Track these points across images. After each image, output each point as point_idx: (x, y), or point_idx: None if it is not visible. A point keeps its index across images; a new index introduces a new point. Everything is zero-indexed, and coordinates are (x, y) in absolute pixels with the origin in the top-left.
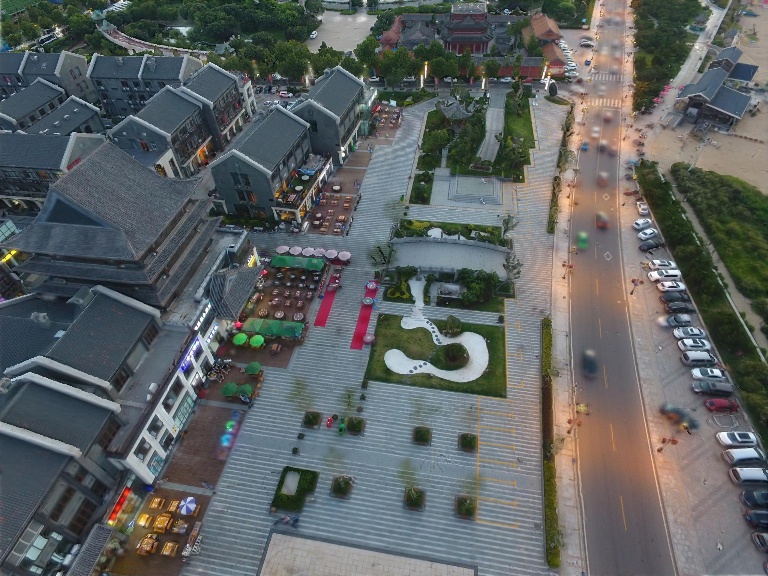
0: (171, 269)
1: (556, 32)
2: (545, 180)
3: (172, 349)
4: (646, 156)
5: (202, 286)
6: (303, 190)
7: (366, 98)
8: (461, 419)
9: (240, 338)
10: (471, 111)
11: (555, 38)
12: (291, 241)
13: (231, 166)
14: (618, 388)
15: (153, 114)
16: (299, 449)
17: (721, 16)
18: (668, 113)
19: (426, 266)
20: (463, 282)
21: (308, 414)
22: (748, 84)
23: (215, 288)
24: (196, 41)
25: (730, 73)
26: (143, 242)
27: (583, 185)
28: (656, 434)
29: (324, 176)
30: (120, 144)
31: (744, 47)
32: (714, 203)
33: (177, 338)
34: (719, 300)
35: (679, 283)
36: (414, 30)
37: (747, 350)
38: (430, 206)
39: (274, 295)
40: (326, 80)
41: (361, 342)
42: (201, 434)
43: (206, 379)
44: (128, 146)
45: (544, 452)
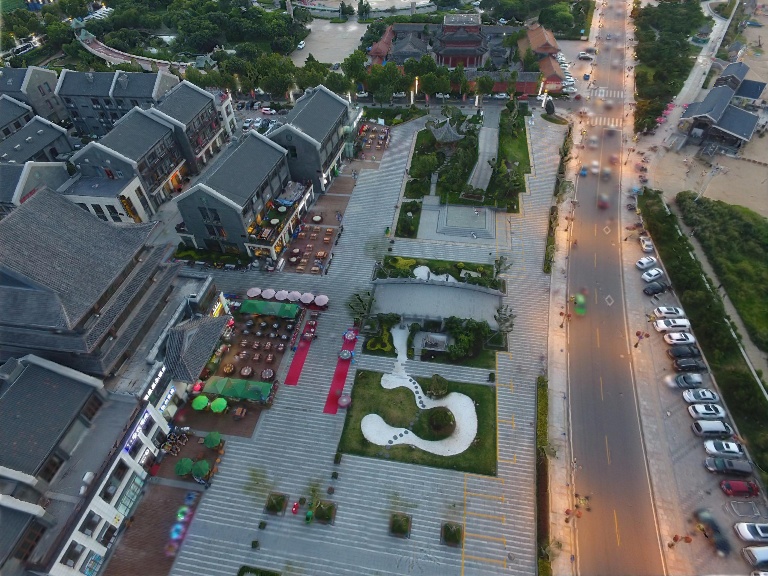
0: (119, 329)
1: (553, 45)
2: (541, 210)
3: (116, 425)
4: (649, 183)
5: (156, 345)
6: (279, 224)
7: (351, 119)
8: (445, 503)
9: (200, 402)
10: (463, 131)
11: (552, 52)
12: (265, 281)
13: (198, 200)
14: (622, 463)
15: (118, 139)
16: (259, 542)
17: (724, 27)
18: (672, 134)
19: (410, 313)
20: (450, 332)
21: (271, 498)
22: (755, 102)
23: (172, 346)
24: (178, 52)
25: (737, 91)
26: (81, 306)
27: (582, 216)
28: (666, 524)
29: (304, 206)
30: (83, 171)
31: (749, 60)
32: (723, 238)
33: (123, 411)
34: (732, 355)
35: (688, 335)
36: (405, 42)
37: (766, 419)
38: (417, 240)
39: (242, 347)
40: (307, 101)
41: (336, 405)
42: (149, 522)
43: (159, 452)
44: (92, 173)
45: (539, 547)
